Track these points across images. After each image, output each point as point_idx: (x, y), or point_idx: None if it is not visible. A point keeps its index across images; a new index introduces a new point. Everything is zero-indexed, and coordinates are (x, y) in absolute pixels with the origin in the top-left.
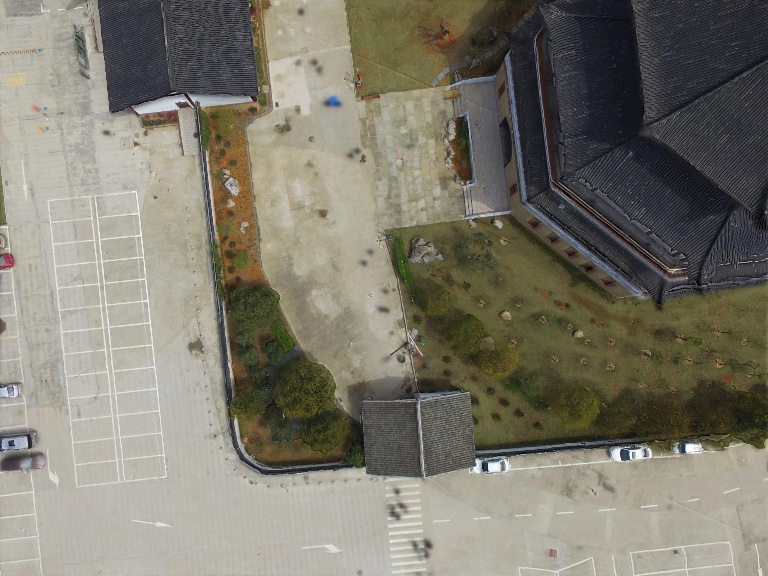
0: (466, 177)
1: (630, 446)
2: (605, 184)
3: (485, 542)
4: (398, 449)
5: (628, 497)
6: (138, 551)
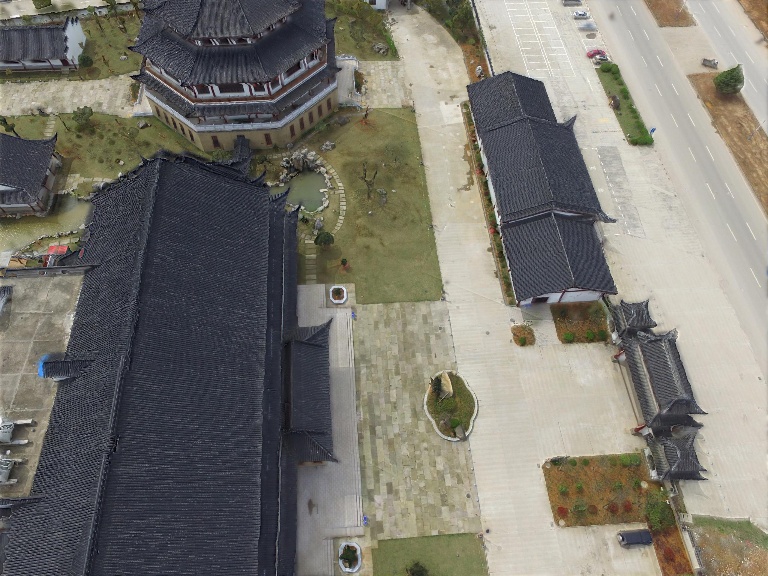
0: None
1: None
2: None
3: None
4: None
5: None
6: None
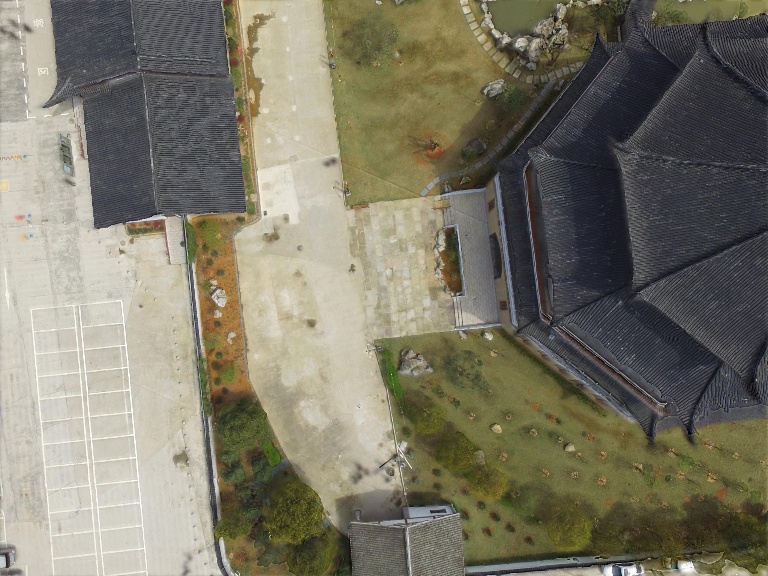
0: (456, 288)
1: (622, 562)
2: (595, 329)
3: None
4: (386, 575)
5: None
6: None
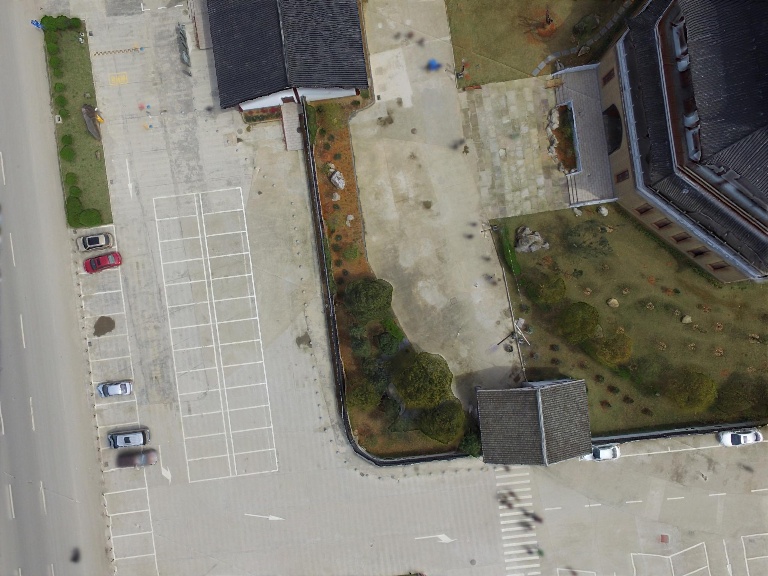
0: (571, 165)
1: (741, 430)
2: (744, 167)
3: (596, 529)
4: (517, 437)
5: (738, 481)
6: (252, 545)
